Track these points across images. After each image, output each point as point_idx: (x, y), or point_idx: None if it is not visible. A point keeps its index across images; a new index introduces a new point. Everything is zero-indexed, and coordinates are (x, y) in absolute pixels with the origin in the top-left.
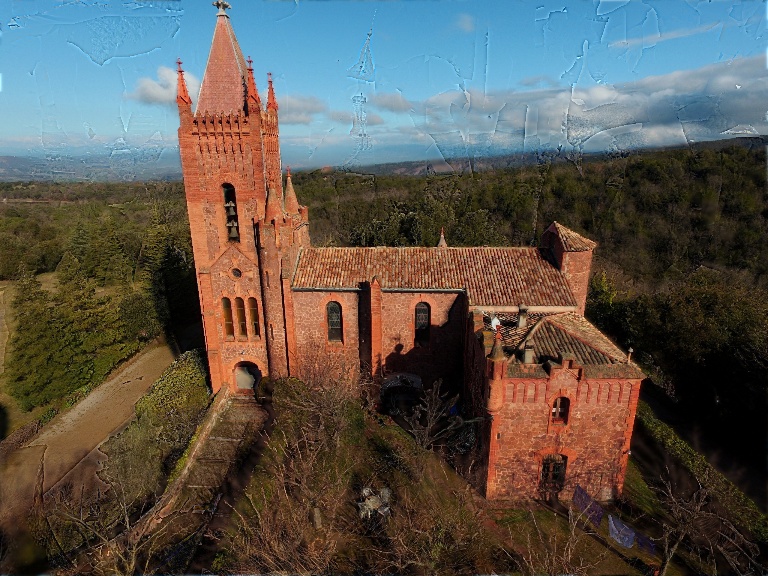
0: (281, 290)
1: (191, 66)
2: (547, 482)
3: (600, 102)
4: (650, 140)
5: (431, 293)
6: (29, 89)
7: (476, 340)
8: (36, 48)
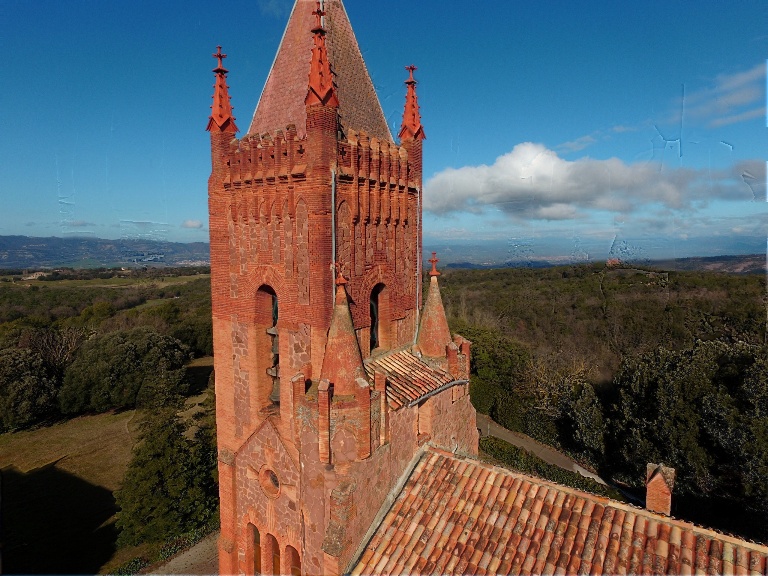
0: None
1: (449, 153)
2: None
3: None
4: None
5: None
6: None
7: None
8: None
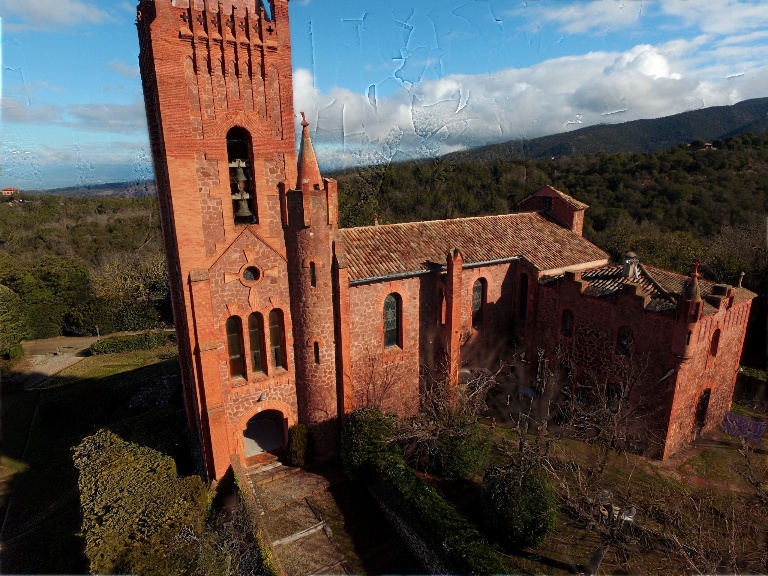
0: (332, 287)
1: None
2: (694, 422)
3: (440, 98)
4: (476, 135)
5: (488, 266)
6: None
7: (580, 301)
8: None
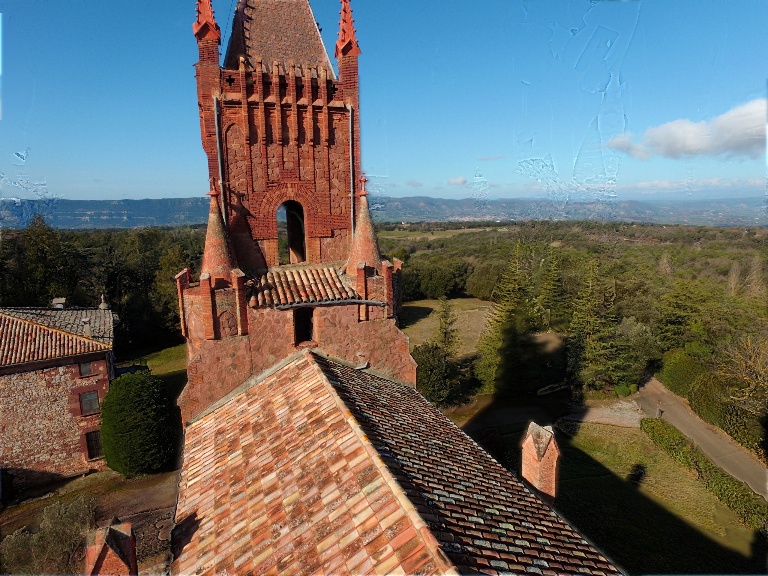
0: None
1: (706, 67)
2: None
3: None
4: None
5: None
6: (534, 131)
7: None
8: (450, 81)
